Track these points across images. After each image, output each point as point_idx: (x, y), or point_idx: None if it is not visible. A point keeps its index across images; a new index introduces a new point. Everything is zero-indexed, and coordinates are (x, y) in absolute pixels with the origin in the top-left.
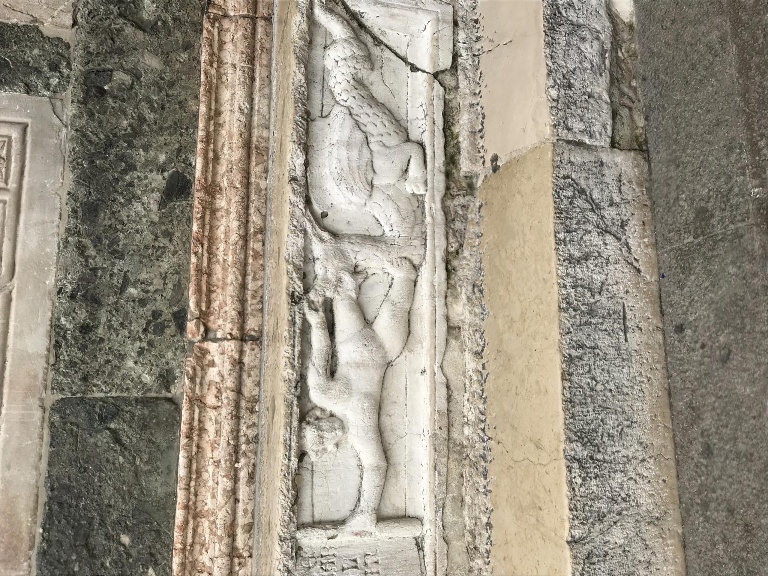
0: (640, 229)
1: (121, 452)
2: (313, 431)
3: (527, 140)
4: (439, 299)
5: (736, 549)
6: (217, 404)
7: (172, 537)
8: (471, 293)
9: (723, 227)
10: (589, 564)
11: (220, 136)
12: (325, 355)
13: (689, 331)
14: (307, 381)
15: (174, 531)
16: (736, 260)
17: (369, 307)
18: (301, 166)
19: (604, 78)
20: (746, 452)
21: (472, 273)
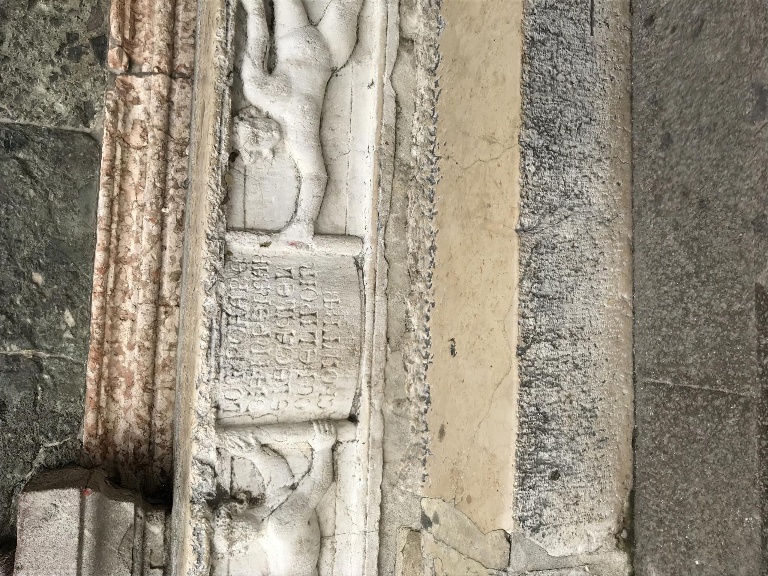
0: None
1: (32, 185)
2: (247, 127)
3: None
4: (392, 5)
5: (688, 230)
6: (142, 144)
7: (91, 280)
8: (427, 5)
9: None
10: (537, 254)
11: None
12: (262, 46)
13: (659, 19)
14: (241, 74)
15: (93, 274)
16: None
17: (314, 8)
18: None
19: None
20: (710, 124)
21: None
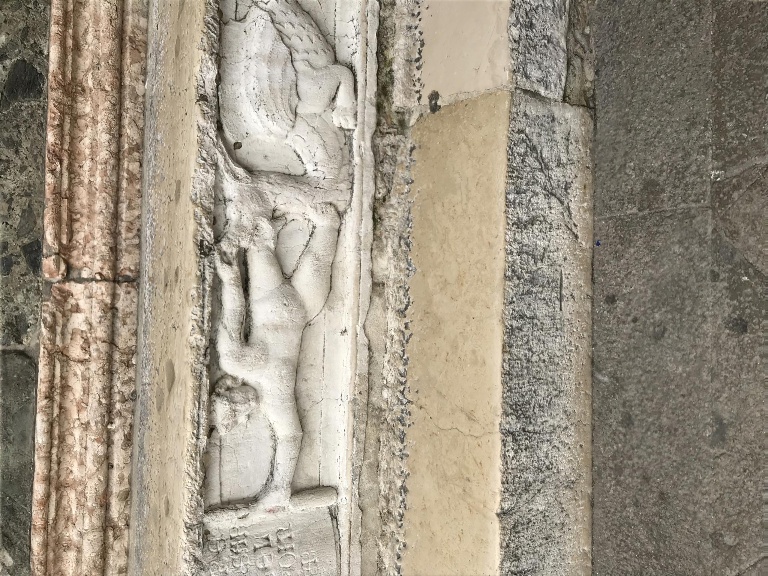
0: (581, 193)
1: None
2: (224, 404)
3: (480, 83)
4: (364, 252)
5: (648, 513)
6: (84, 357)
7: (29, 512)
8: (397, 246)
9: (674, 204)
10: (515, 533)
11: (81, 19)
12: (239, 316)
13: (622, 303)
14: (217, 346)
15: (32, 505)
16: (685, 240)
17: (287, 259)
18: (212, 83)
19: (564, 22)
20: (671, 427)
21: (399, 224)
